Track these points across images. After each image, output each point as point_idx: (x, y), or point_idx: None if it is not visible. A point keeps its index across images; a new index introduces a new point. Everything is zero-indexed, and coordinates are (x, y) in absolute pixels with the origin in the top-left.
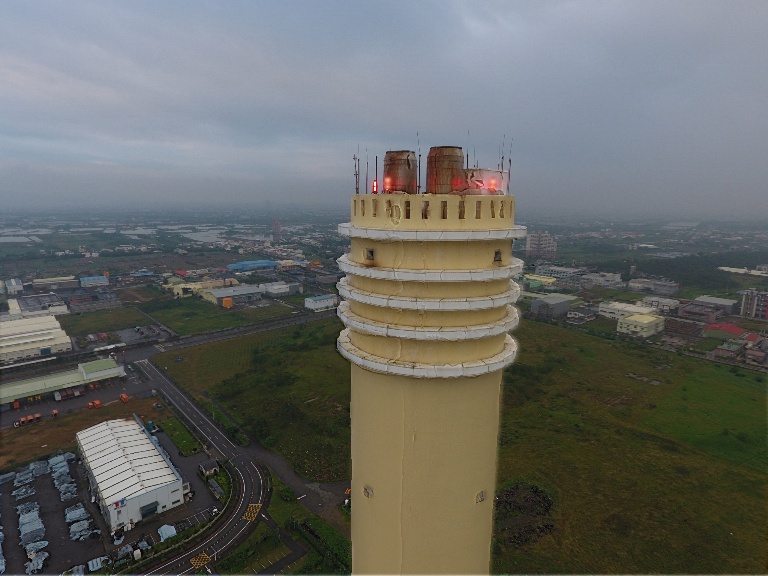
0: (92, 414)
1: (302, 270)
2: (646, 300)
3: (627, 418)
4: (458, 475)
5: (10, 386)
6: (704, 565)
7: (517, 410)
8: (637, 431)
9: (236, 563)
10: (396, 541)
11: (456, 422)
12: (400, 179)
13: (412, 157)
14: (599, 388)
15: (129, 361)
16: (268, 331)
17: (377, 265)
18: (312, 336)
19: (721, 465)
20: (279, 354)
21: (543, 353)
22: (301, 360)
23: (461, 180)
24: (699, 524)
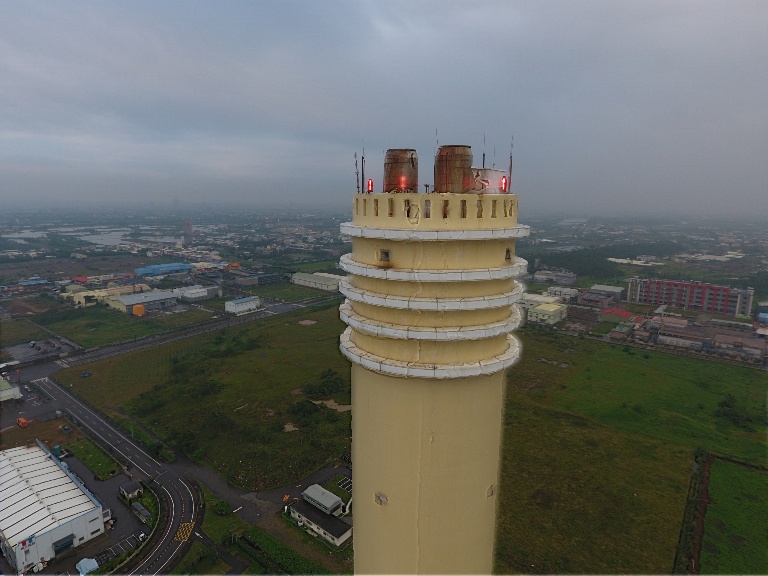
0: None
1: (220, 272)
2: (550, 290)
3: (543, 400)
4: (472, 472)
5: None
6: (616, 526)
7: None
8: (552, 411)
9: None
10: (412, 546)
11: (471, 420)
12: (404, 178)
13: (416, 156)
14: (517, 374)
15: (25, 381)
16: (187, 338)
17: (394, 266)
18: (236, 341)
19: (622, 435)
20: (201, 362)
21: None
22: (226, 366)
23: (472, 179)
24: (609, 490)
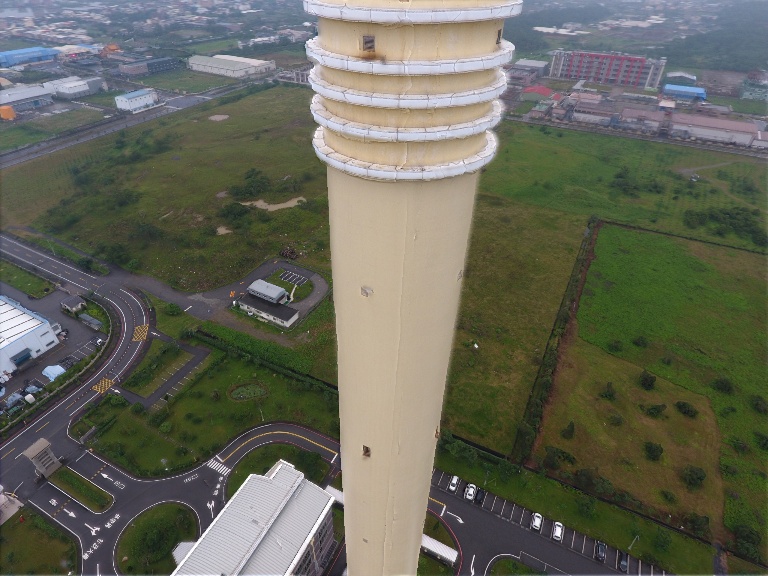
0: None
1: (96, 58)
2: None
3: None
4: (448, 262)
5: None
6: (519, 285)
7: None
8: None
9: (143, 378)
10: (394, 325)
11: (451, 217)
12: None
13: None
14: None
15: None
16: (81, 144)
17: (381, 58)
18: (141, 143)
19: (532, 210)
20: (107, 170)
21: None
22: (137, 173)
23: None
24: (516, 257)
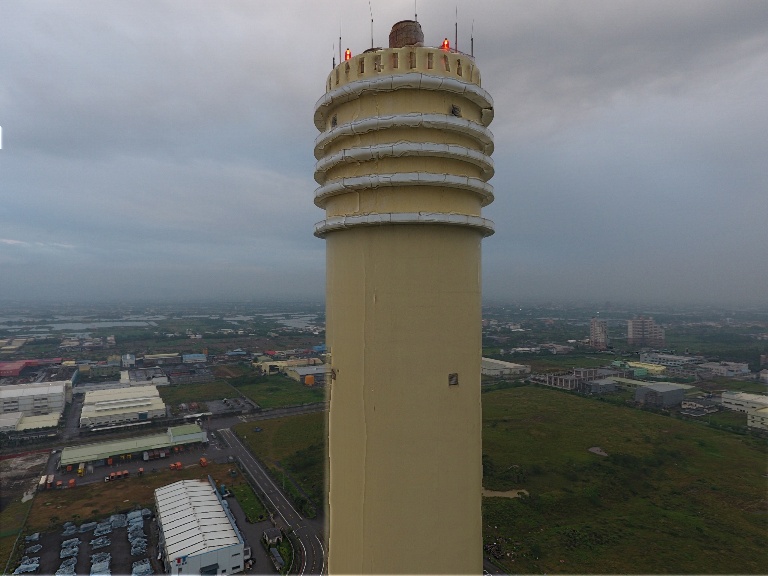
0: (173, 475)
1: None
2: None
3: None
4: (424, 345)
5: (108, 444)
6: None
7: (620, 506)
8: None
9: None
10: (361, 426)
11: (419, 282)
12: None
13: None
14: (727, 488)
15: (213, 429)
16: None
17: (339, 126)
18: None
19: None
20: None
21: (652, 444)
22: None
23: None
24: None
